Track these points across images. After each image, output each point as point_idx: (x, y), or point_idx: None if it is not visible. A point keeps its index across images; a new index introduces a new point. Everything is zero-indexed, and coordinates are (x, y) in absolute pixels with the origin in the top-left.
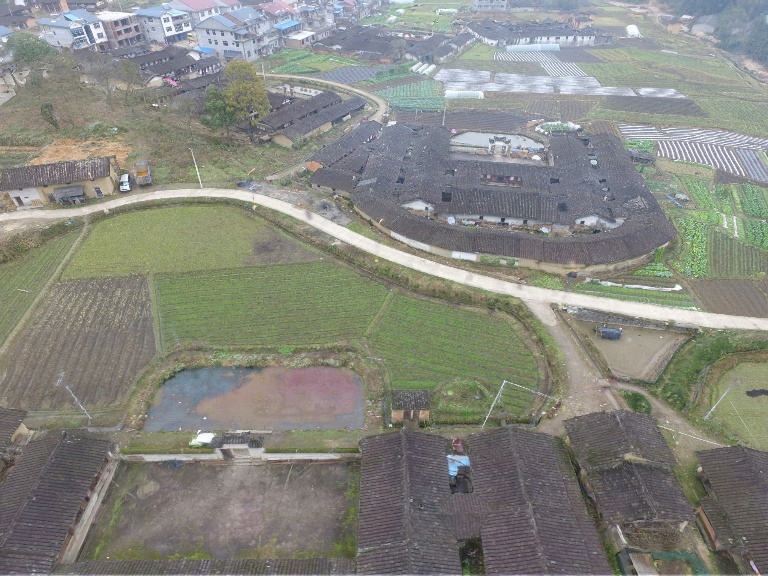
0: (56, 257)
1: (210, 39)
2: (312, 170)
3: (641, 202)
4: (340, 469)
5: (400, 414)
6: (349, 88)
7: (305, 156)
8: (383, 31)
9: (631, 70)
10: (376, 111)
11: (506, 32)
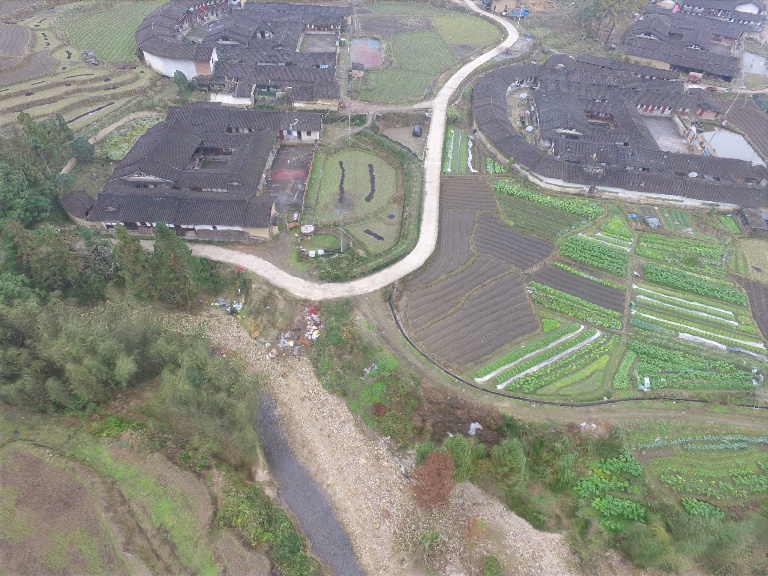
0: None
1: None
2: None
3: None
4: None
5: None
6: None
7: None
8: None
9: None
10: (734, 88)
11: None
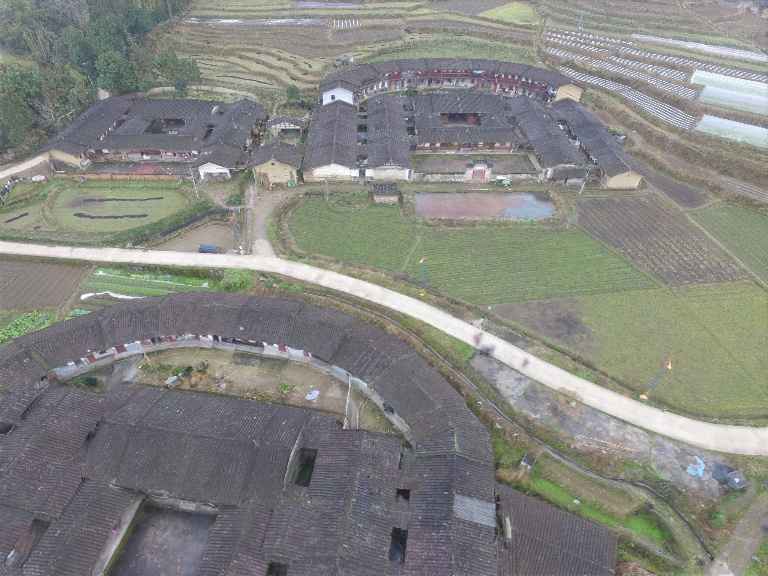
0: None
1: None
2: None
3: None
4: None
5: None
6: None
7: None
8: None
9: None
10: None
11: None
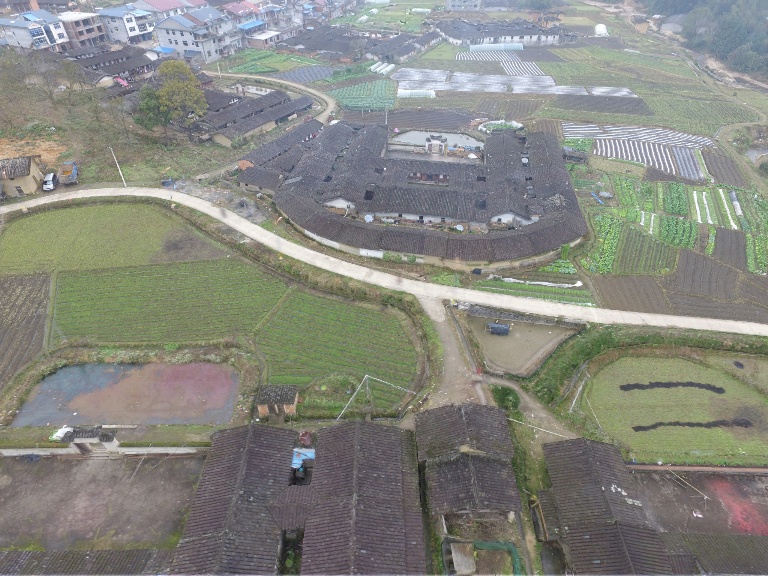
0: None
1: (170, 39)
2: (244, 169)
3: (558, 200)
4: (195, 463)
5: (265, 409)
6: (302, 87)
7: (243, 155)
8: (350, 31)
9: (589, 69)
10: (324, 110)
11: (472, 32)
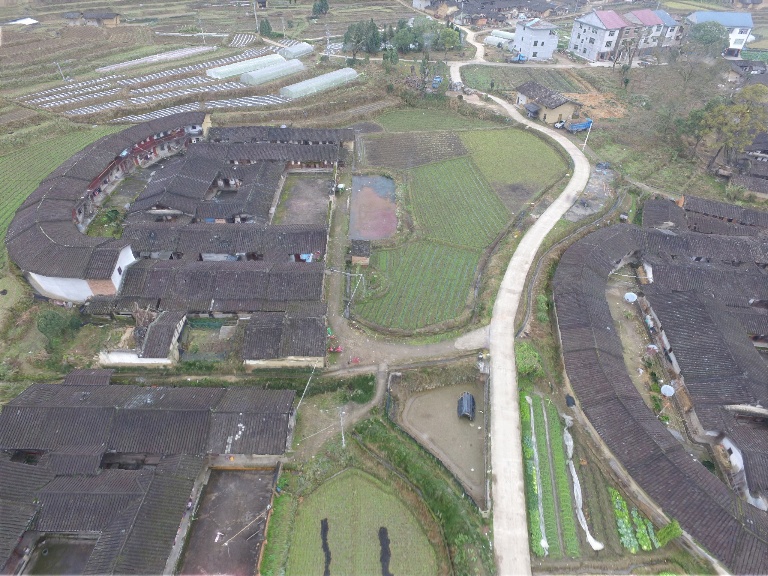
0: (475, 126)
1: None
2: None
3: None
4: None
5: None
6: None
7: None
8: None
9: None
10: None
11: None
